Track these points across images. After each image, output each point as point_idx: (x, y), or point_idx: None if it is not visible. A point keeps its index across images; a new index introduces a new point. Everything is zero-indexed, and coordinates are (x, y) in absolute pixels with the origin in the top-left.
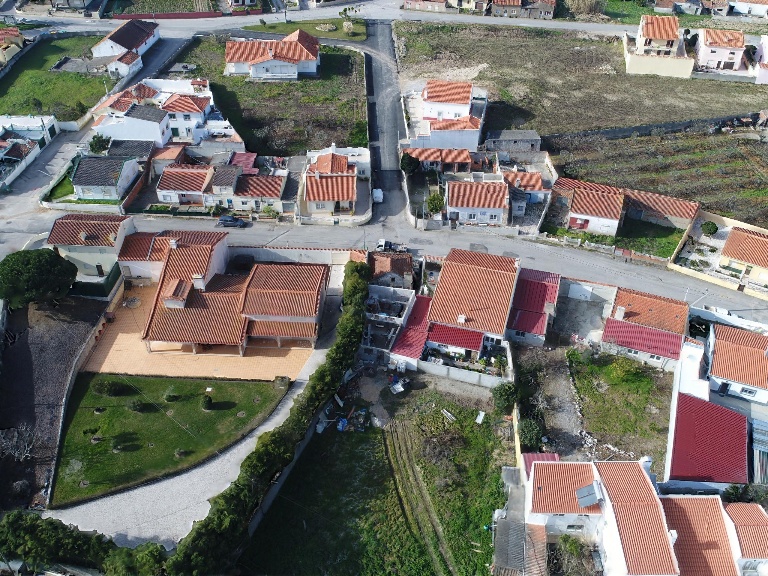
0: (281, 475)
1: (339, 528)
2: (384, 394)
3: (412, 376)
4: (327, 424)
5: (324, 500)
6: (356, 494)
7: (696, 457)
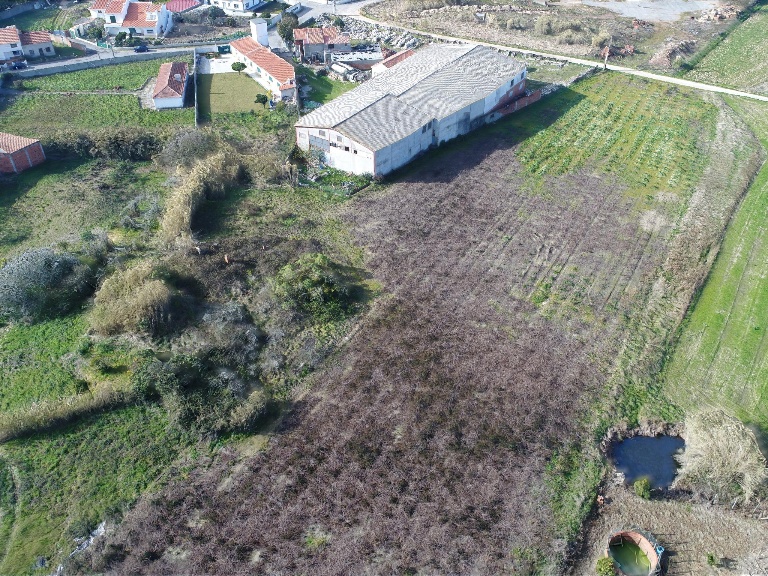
0: (11, 10)
1: (27, 22)
2: (70, 3)
3: (85, 0)
4: (40, 7)
5: (26, 18)
6: (39, 18)
7: (167, 7)
